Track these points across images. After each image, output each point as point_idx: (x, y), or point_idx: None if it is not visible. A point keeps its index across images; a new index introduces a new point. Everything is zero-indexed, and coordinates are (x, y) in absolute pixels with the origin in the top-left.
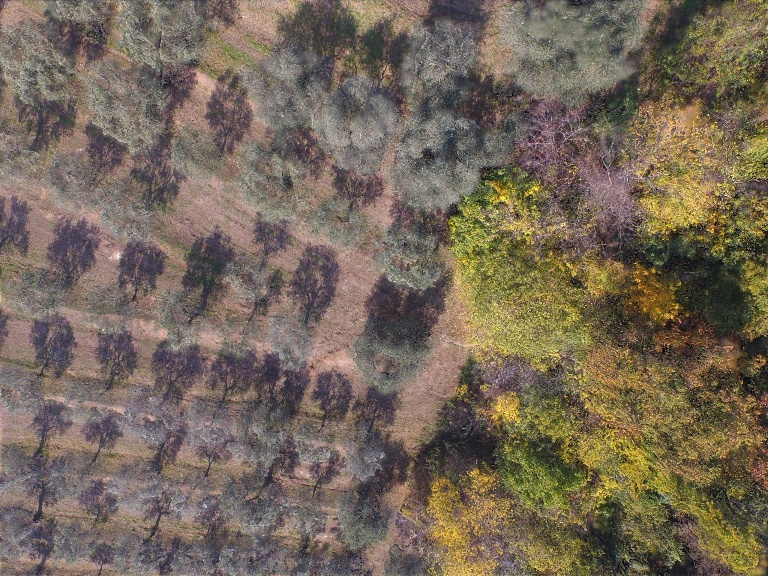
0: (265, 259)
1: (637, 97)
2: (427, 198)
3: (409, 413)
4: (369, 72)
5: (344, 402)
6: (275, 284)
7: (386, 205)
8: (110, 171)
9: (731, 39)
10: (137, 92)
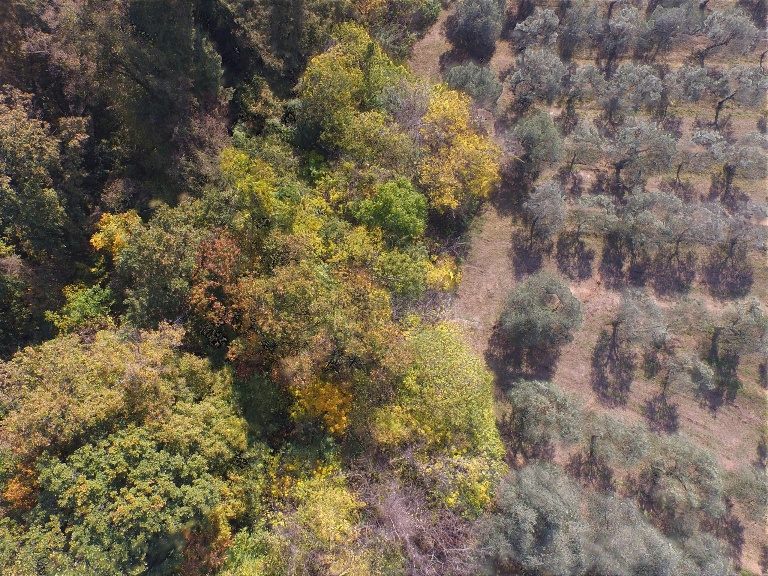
0: (663, 389)
1: None
2: (527, 470)
3: (498, 246)
4: None
5: (562, 251)
6: (650, 365)
7: (560, 456)
8: None
9: None
10: None
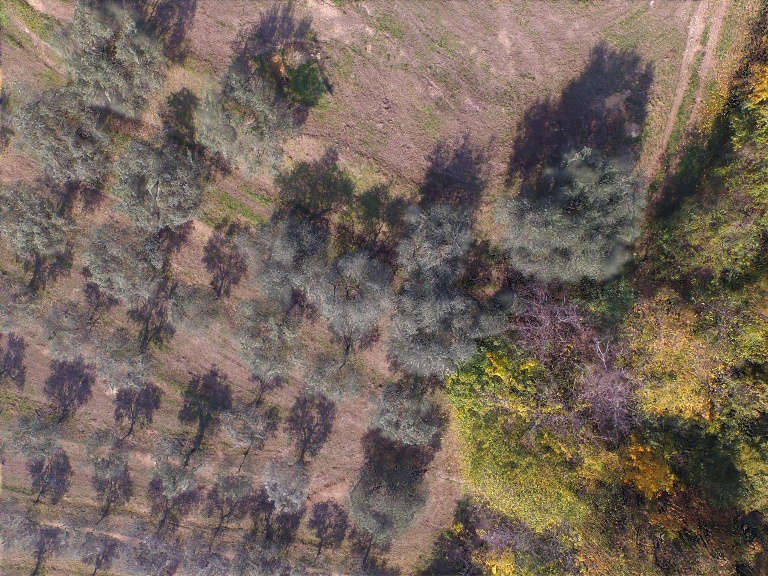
0: (261, 396)
1: (633, 262)
2: None
3: (405, 542)
4: (366, 227)
5: (340, 531)
6: (271, 420)
7: (382, 350)
8: (107, 310)
9: (726, 233)
10: (134, 236)
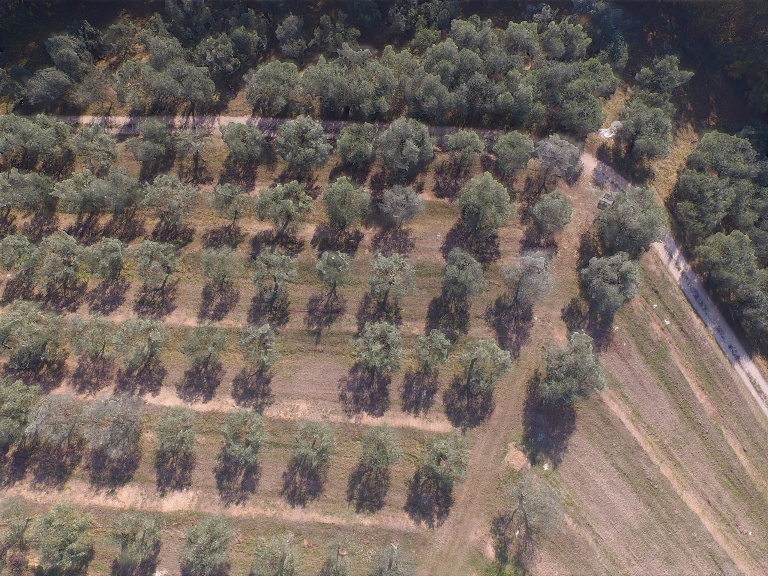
0: None
1: None
2: None
3: None
4: None
5: None
6: None
7: None
8: None
9: None
10: None
